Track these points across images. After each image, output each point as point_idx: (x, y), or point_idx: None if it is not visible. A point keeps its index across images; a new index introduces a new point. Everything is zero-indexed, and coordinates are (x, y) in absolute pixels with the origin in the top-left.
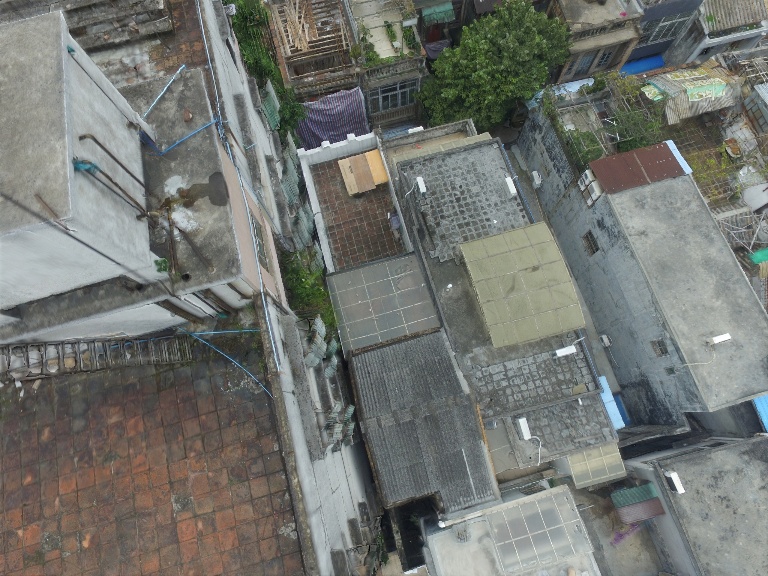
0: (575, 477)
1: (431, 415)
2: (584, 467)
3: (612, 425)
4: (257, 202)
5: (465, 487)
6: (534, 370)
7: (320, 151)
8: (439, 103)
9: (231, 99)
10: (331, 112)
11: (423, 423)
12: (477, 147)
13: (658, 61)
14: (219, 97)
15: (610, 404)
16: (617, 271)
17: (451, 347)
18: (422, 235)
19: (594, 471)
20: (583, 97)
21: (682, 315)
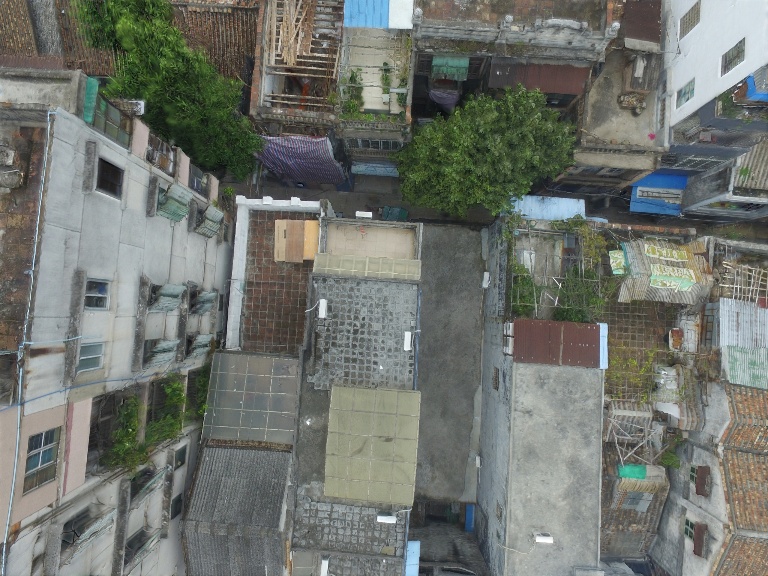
0: None
1: (244, 536)
2: None
3: None
4: (65, 399)
5: None
6: (356, 520)
7: (260, 204)
8: None
9: (65, 284)
10: (295, 150)
11: (235, 539)
12: (396, 282)
13: (681, 182)
14: (31, 311)
15: (413, 567)
16: (500, 424)
17: (290, 476)
18: (308, 355)
19: None
20: (554, 230)
21: (524, 502)
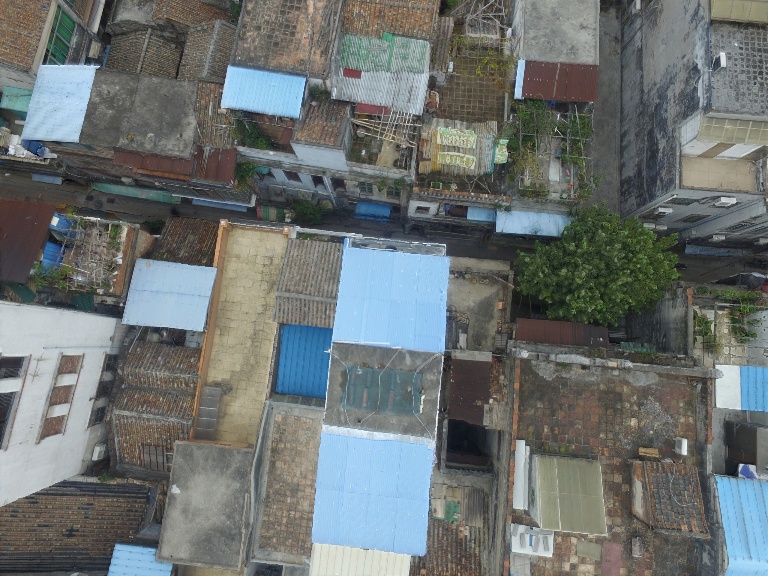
0: None
1: None
2: None
3: None
4: None
5: None
6: None
7: None
8: None
9: None
10: None
11: None
12: None
13: None
14: None
15: None
16: None
17: None
18: None
19: None
20: None
21: None
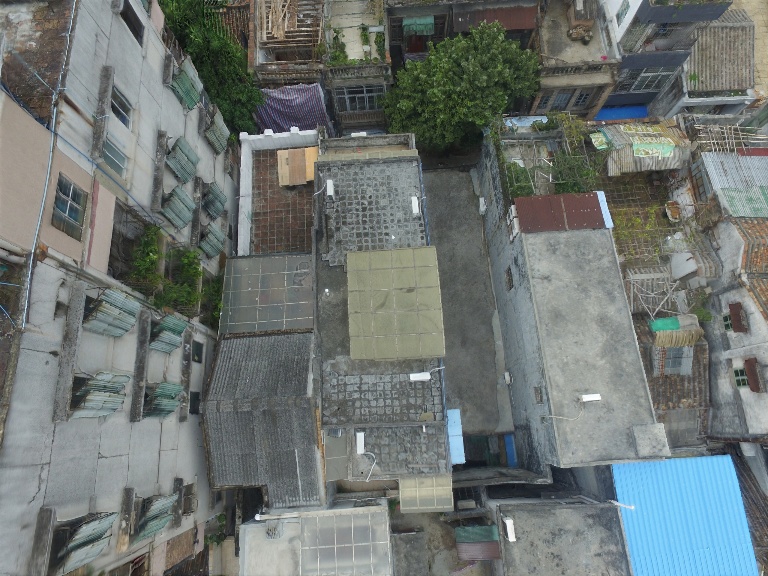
0: (402, 501)
1: (270, 410)
2: (414, 493)
3: (449, 458)
4: (92, 170)
5: (292, 487)
6: (388, 389)
7: (262, 138)
8: (399, 113)
9: (95, 69)
10: (290, 103)
11: (261, 416)
12: (397, 161)
13: (642, 111)
14: (66, 65)
15: (456, 438)
16: (521, 311)
17: (313, 350)
18: (320, 237)
19: (422, 499)
20: (536, 133)
21: (562, 367)
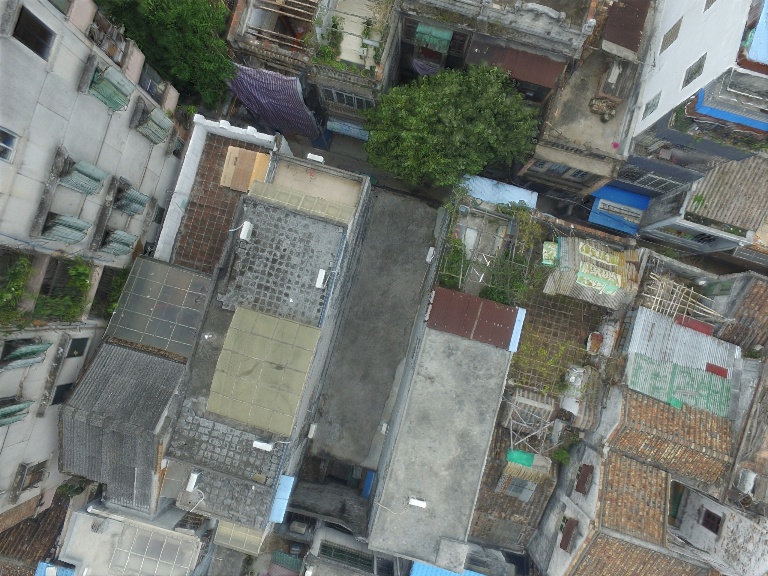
0: (217, 535)
1: (118, 432)
2: (229, 532)
3: (266, 518)
4: None
5: (128, 493)
6: (234, 442)
7: (217, 127)
8: None
9: None
10: (266, 86)
11: (110, 434)
12: (324, 221)
13: (642, 202)
14: None
15: (282, 501)
16: (405, 389)
17: (179, 386)
18: (223, 274)
19: (234, 539)
20: (499, 213)
21: (407, 464)
